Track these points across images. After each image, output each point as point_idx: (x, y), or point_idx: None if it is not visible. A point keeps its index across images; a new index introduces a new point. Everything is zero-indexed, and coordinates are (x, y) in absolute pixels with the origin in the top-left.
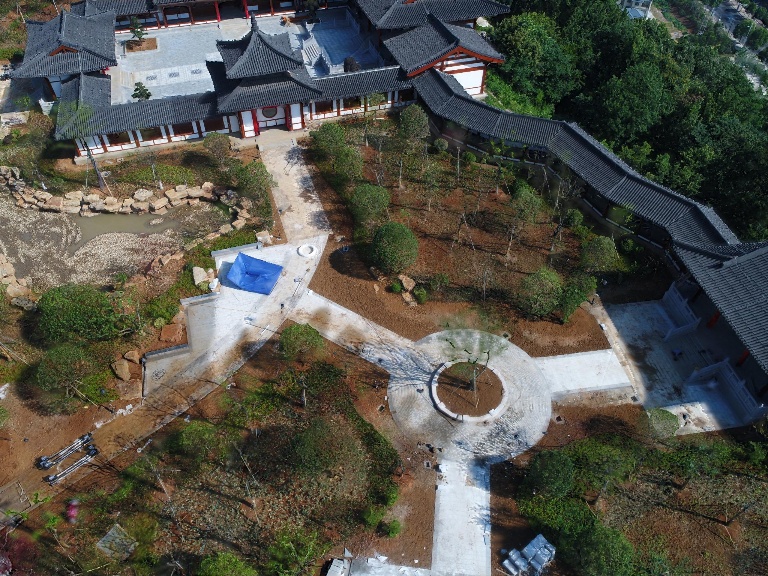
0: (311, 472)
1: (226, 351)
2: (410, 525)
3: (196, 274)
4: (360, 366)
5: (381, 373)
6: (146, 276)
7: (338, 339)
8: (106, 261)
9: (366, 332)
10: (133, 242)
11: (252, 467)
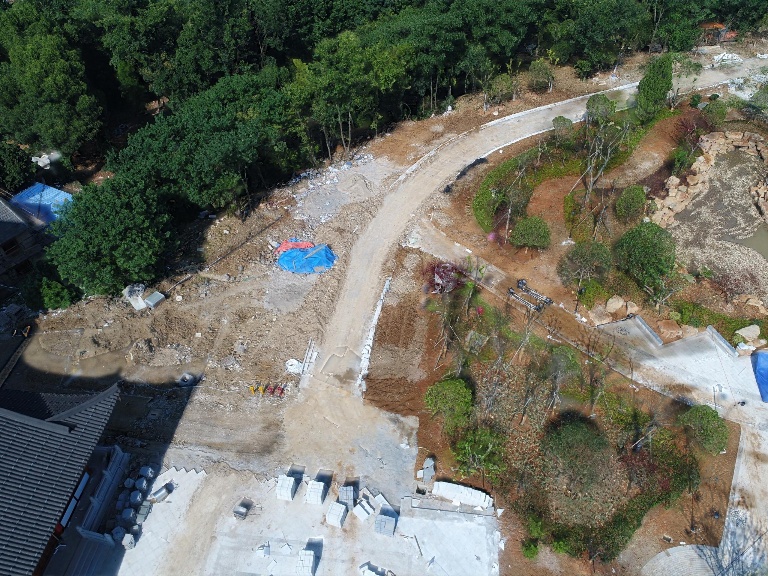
0: (553, 446)
1: (671, 376)
2: (541, 573)
3: (749, 329)
4: (713, 509)
5: (715, 535)
6: (723, 292)
7: (740, 482)
8: (727, 263)
9: (767, 514)
10: (763, 275)
11: (557, 417)
